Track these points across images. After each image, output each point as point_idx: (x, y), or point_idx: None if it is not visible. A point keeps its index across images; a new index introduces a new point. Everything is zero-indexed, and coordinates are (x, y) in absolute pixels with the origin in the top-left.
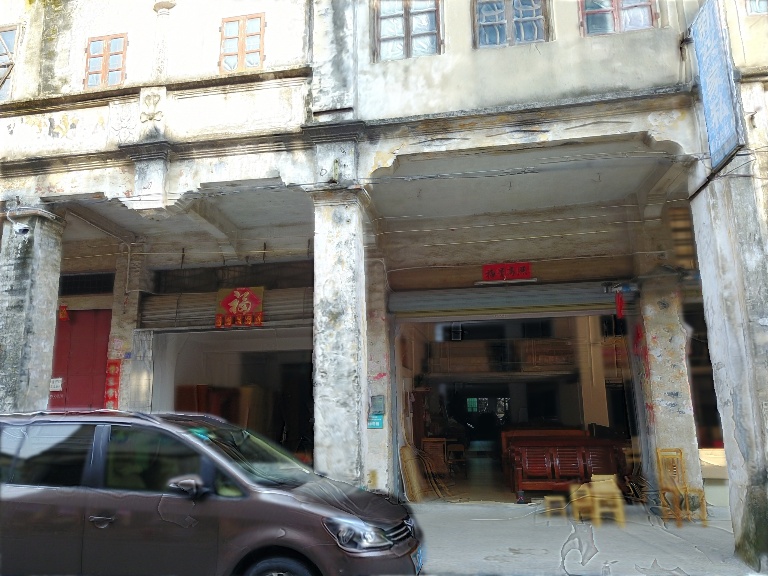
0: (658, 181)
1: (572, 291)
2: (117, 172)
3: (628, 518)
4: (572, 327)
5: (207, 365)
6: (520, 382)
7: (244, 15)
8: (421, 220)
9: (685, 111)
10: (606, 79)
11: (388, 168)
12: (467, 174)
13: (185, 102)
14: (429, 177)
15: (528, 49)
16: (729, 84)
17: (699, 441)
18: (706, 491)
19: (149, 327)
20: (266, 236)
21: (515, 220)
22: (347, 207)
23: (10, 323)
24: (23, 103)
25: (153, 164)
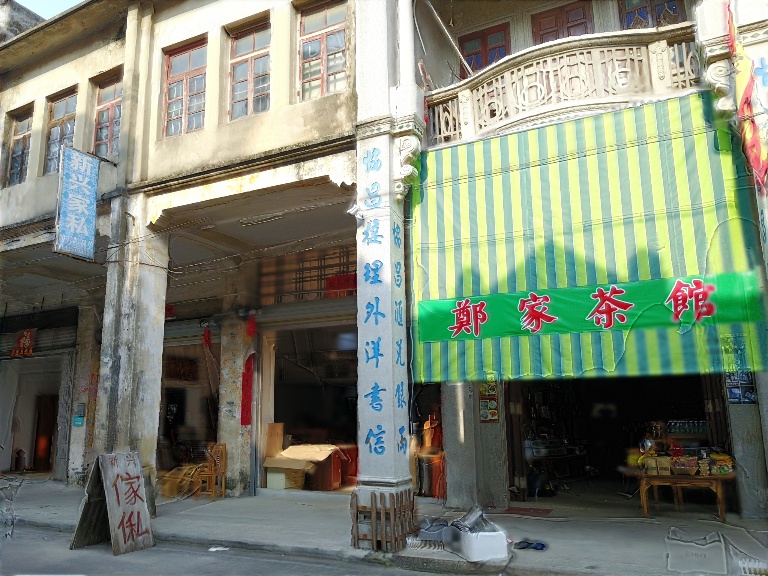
0: None
1: (191, 326)
2: None
3: (165, 492)
4: (197, 352)
5: (19, 382)
6: (179, 393)
7: None
8: None
9: None
10: None
11: None
12: None
13: None
14: None
15: None
16: None
17: (308, 438)
18: (269, 477)
19: None
20: (44, 292)
21: None
22: None
23: None
24: None
25: None
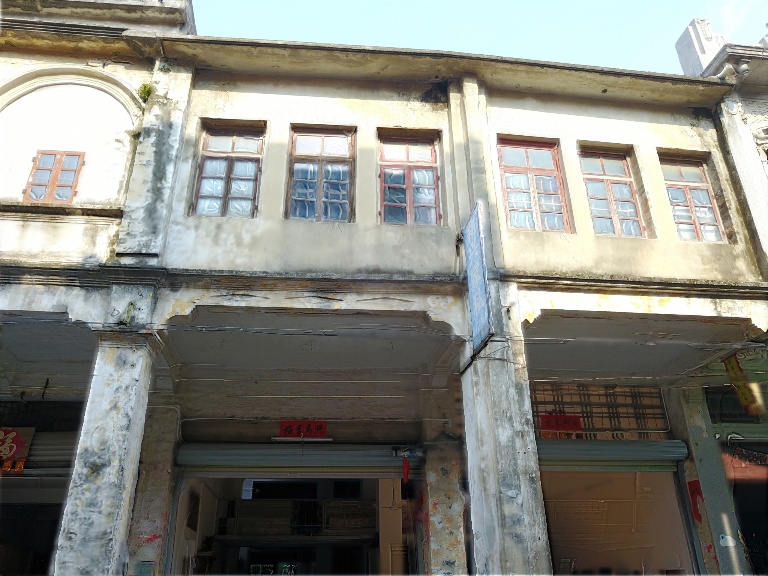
0: (442, 355)
1: (365, 453)
2: None
3: None
4: (363, 490)
5: None
6: (308, 547)
7: (62, 151)
8: (225, 370)
9: (457, 298)
10: (395, 262)
11: (186, 316)
12: (270, 330)
13: None
14: (223, 330)
15: (331, 226)
16: (484, 282)
17: None
18: None
19: None
20: (51, 371)
21: (318, 378)
22: (135, 351)
23: None
24: None
25: None
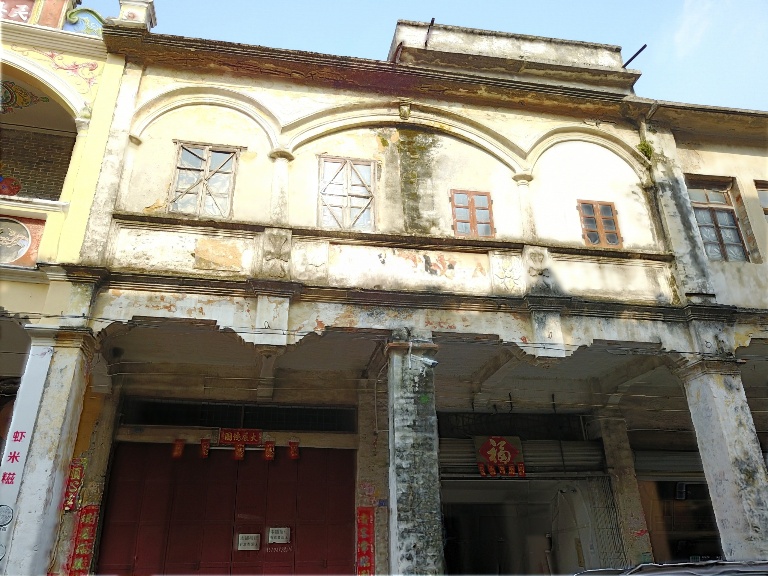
0: None
1: None
2: (509, 317)
3: None
4: None
5: (454, 516)
6: None
7: (596, 201)
8: (648, 387)
9: None
10: None
11: (744, 347)
12: (742, 356)
13: (562, 264)
14: None
15: None
16: None
17: None
18: None
19: None
20: (511, 387)
21: None
22: (734, 377)
23: (420, 462)
24: (401, 237)
25: (550, 316)
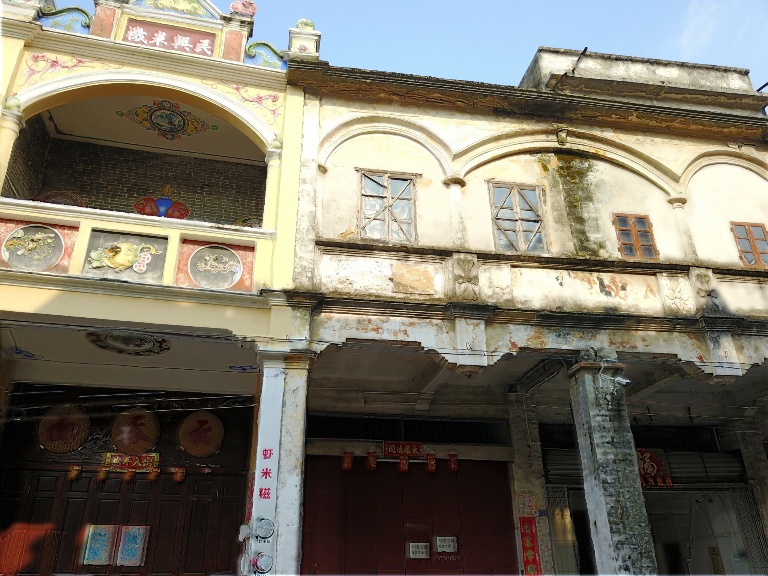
0: None
1: None
2: (684, 337)
3: None
4: None
5: None
6: None
7: (748, 222)
8: None
9: None
10: None
11: None
12: None
13: (725, 285)
14: None
15: None
16: None
17: None
18: None
19: (556, 483)
20: (648, 400)
21: None
22: None
23: (623, 477)
24: (577, 260)
25: (723, 335)
